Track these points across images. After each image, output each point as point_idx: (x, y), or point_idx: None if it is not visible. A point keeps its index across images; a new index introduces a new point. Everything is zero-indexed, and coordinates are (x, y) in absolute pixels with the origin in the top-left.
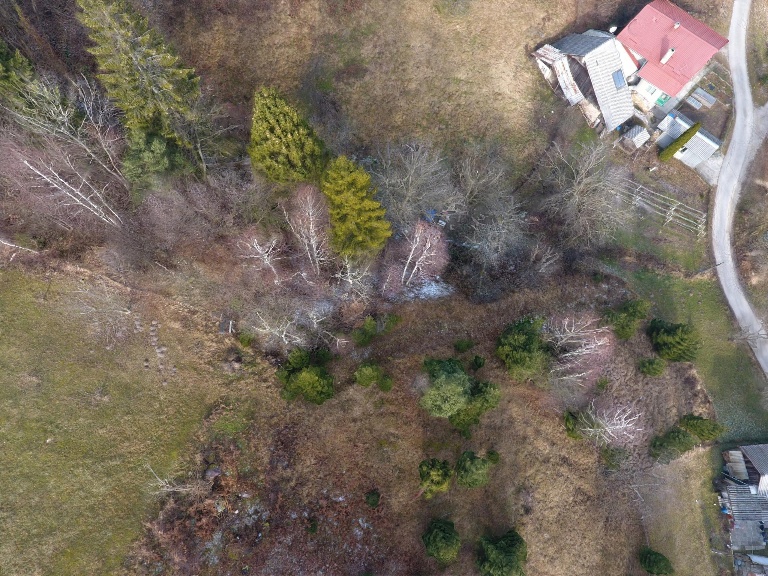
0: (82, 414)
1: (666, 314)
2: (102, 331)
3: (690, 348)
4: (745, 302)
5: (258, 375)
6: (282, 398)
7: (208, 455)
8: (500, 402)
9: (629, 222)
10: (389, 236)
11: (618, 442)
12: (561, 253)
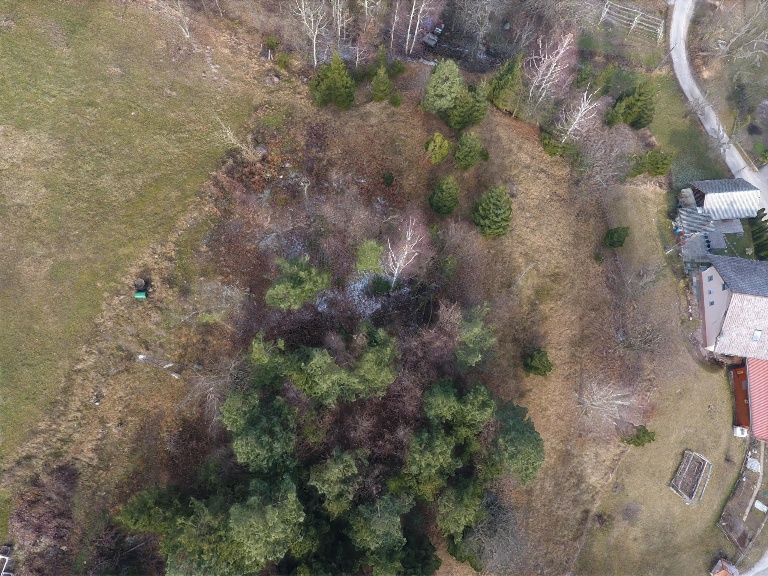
0: (157, 100)
1: None
2: (168, 47)
3: (647, 104)
4: (697, 91)
5: (293, 89)
6: (313, 106)
7: (257, 136)
8: (489, 125)
9: (599, 33)
10: None
11: None
12: None
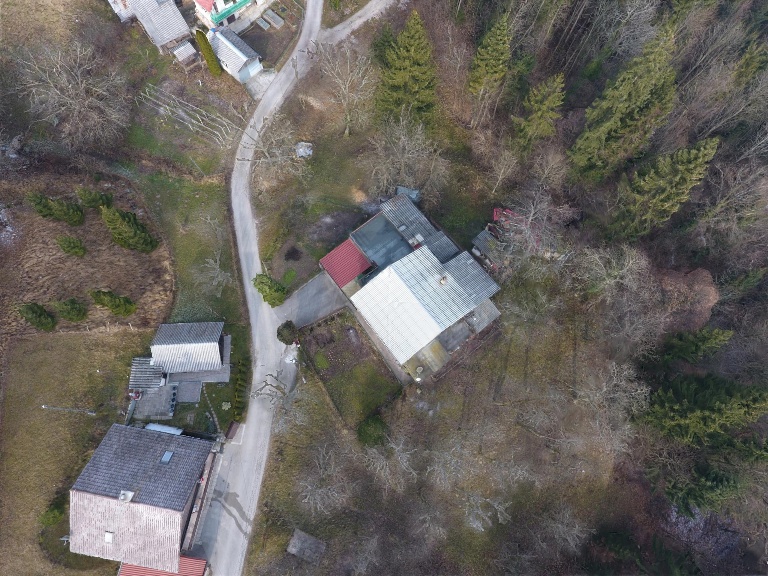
0: None
1: (166, 213)
2: None
3: None
4: (248, 204)
5: None
6: None
7: None
8: None
9: (163, 131)
10: None
11: (5, 309)
12: None
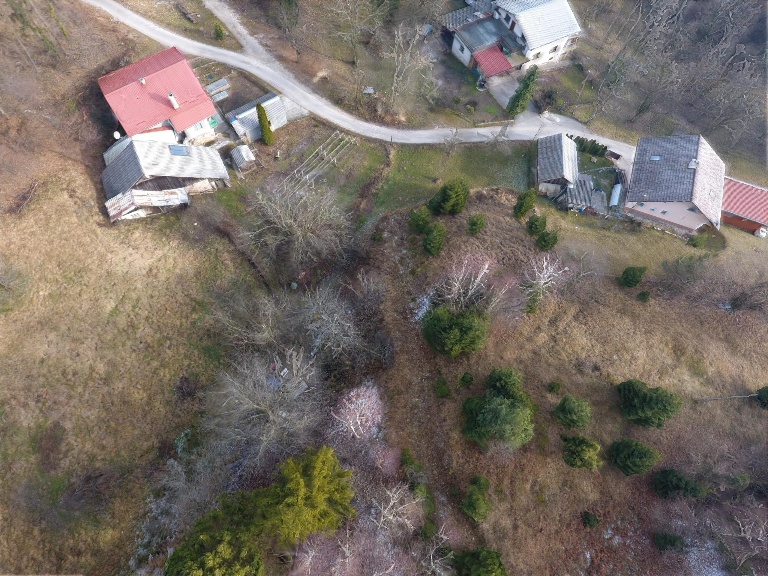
0: None
1: (418, 193)
2: None
3: (462, 189)
4: (419, 132)
5: None
6: None
7: None
8: (502, 367)
9: None
10: None
11: None
12: None
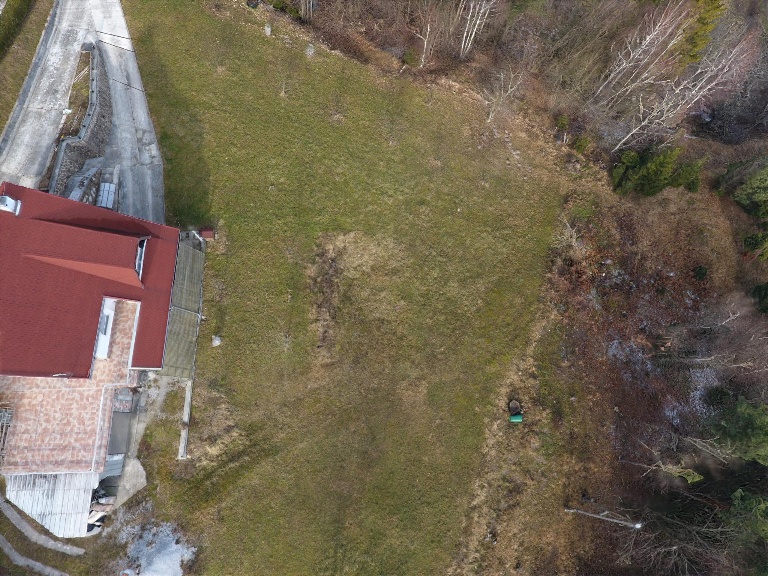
0: (475, 194)
1: None
2: (473, 134)
3: None
4: None
5: (593, 176)
6: (616, 194)
7: None
8: None
9: None
10: None
11: None
12: None
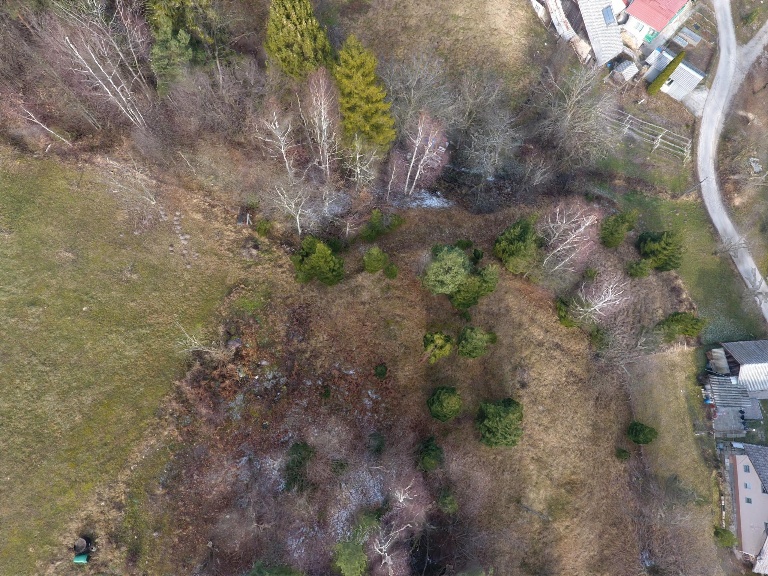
0: (114, 288)
1: None
2: (130, 218)
3: (675, 253)
4: (728, 221)
5: (274, 261)
6: (296, 282)
7: (230, 327)
8: (497, 293)
9: (619, 150)
10: (393, 139)
11: None
12: (555, 177)
